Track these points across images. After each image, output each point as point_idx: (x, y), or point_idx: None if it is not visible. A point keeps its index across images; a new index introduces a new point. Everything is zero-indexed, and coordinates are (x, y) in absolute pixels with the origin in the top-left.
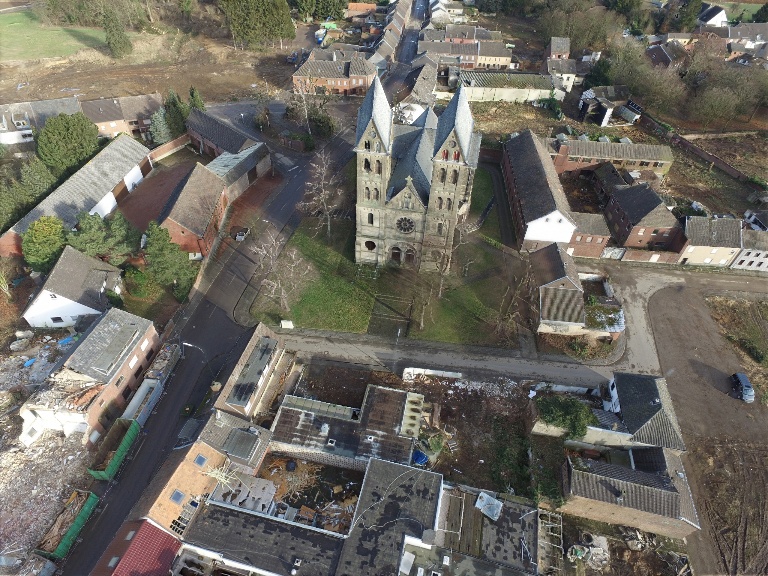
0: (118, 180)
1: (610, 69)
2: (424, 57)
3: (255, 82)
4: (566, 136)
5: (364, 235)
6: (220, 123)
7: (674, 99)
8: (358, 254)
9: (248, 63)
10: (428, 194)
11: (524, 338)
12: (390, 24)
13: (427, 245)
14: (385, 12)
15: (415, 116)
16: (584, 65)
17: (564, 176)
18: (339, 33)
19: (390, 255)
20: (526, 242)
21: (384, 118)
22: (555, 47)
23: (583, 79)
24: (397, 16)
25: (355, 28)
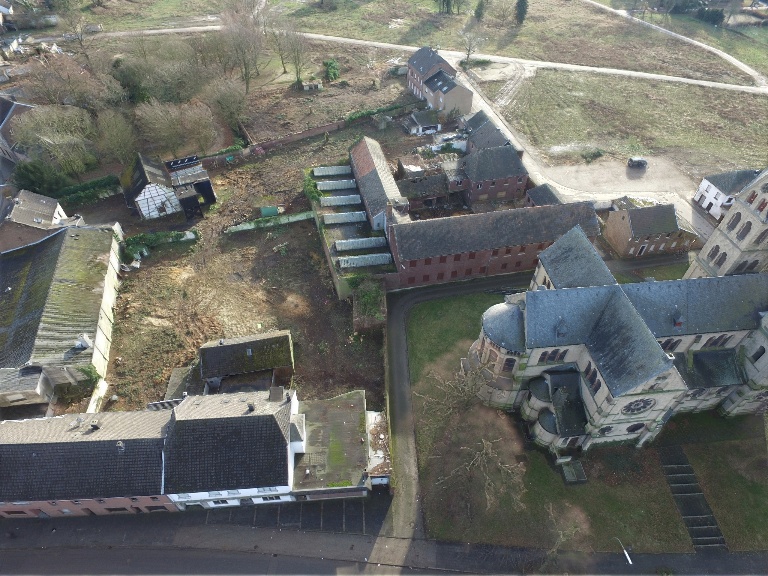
0: None
1: (60, 163)
2: None
3: None
4: None
5: None
6: None
7: (211, 122)
8: None
9: None
10: None
11: None
12: None
13: None
14: None
15: None
16: None
17: None
18: None
19: None
20: None
21: None
22: None
23: None
24: None
25: None
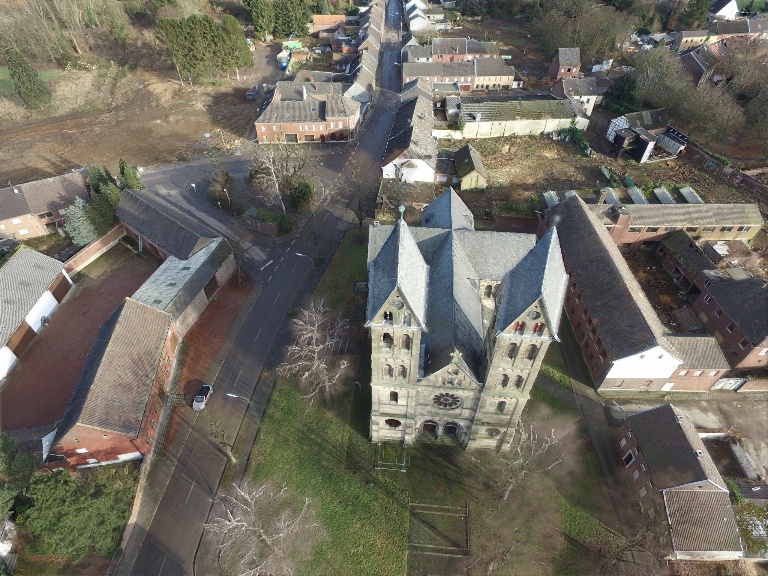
0: (14, 326)
1: (637, 86)
2: (416, 88)
3: (209, 130)
4: (613, 190)
5: (384, 413)
6: (161, 213)
7: (731, 127)
8: (375, 433)
9: (199, 103)
10: (478, 353)
11: (647, 573)
12: (366, 42)
13: (480, 423)
14: (356, 24)
15: (416, 173)
16: (595, 77)
17: (621, 249)
18: (306, 54)
19: (421, 427)
20: (608, 380)
21: (416, 279)
22: (563, 60)
23: (602, 98)
24: (372, 30)
25: (324, 46)
